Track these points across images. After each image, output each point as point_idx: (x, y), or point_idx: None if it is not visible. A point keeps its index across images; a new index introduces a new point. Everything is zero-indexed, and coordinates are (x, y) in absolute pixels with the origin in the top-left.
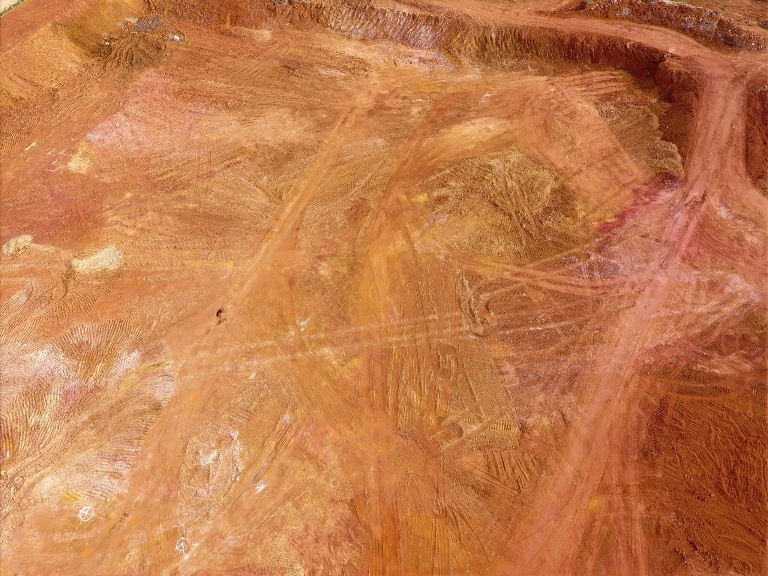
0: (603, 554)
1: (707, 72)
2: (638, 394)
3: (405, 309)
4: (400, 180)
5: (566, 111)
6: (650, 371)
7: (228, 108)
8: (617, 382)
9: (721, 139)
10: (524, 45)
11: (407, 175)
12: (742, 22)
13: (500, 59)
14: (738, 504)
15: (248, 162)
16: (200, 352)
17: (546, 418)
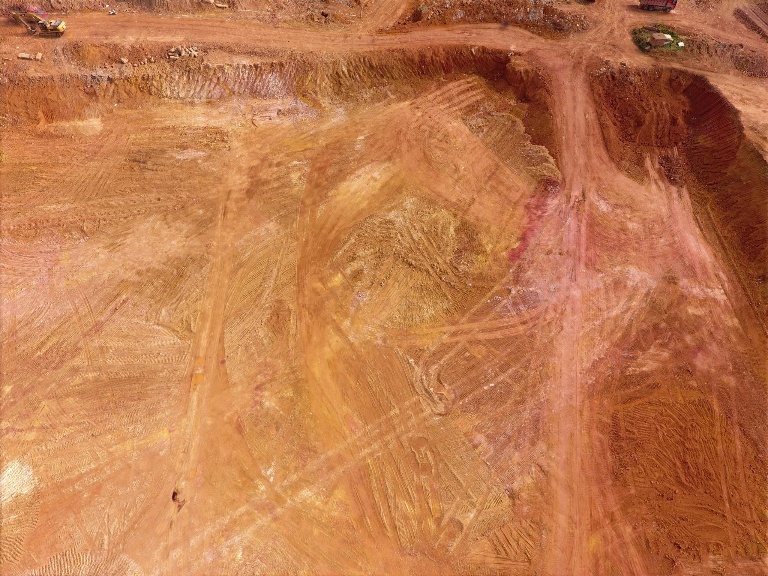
0: None
1: (549, 65)
2: (593, 418)
3: (365, 414)
4: (308, 266)
5: (439, 136)
6: (595, 391)
7: (86, 235)
8: (573, 413)
9: (580, 131)
10: (377, 71)
11: (313, 258)
12: (561, 1)
13: (358, 91)
14: (697, 491)
15: (136, 297)
16: (172, 552)
17: (528, 476)
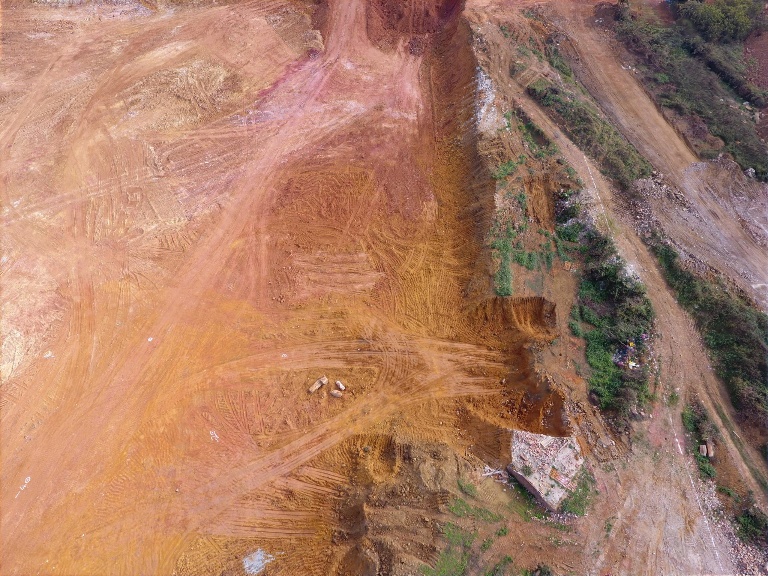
0: (238, 266)
1: None
2: (274, 181)
3: (102, 175)
4: (100, 97)
5: (241, 26)
6: (284, 167)
7: None
8: (260, 178)
9: (350, 20)
10: None
11: (106, 92)
12: None
13: None
14: (330, 218)
15: None
16: None
17: (207, 209)
